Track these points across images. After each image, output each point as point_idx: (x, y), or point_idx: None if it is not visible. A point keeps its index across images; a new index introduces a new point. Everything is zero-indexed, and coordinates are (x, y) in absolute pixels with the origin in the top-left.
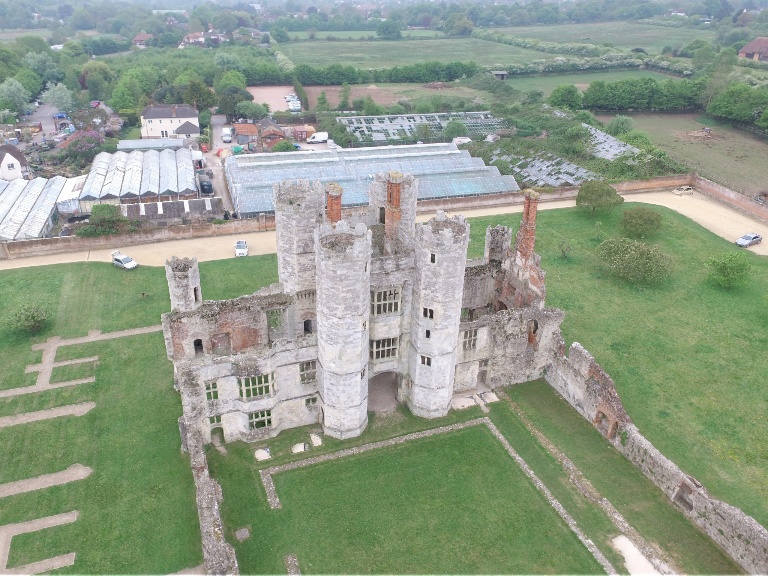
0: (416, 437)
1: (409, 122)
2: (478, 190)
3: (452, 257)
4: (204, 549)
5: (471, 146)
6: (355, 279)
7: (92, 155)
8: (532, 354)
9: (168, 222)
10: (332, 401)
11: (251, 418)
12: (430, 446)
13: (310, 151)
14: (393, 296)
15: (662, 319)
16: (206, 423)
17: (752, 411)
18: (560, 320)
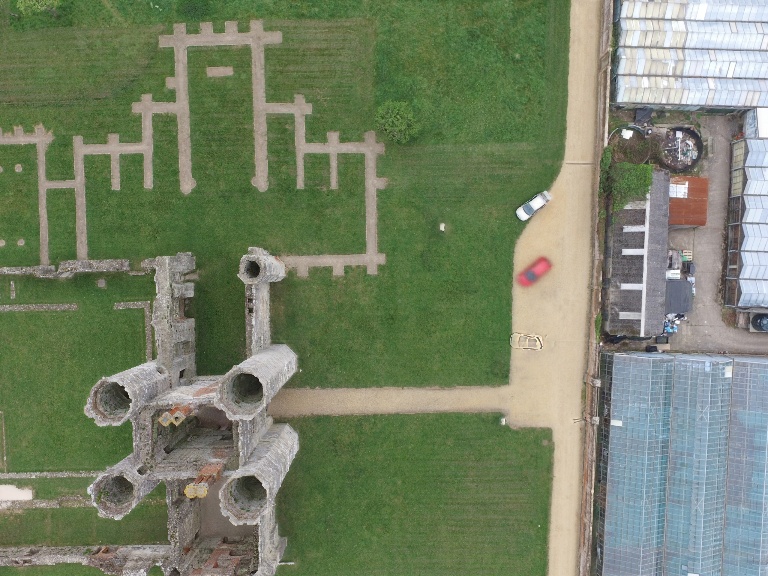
0: None
1: None
2: None
3: None
4: None
5: None
6: None
7: None
8: None
9: None
10: None
11: None
12: None
13: None
14: None
15: None
16: None
17: None
18: None
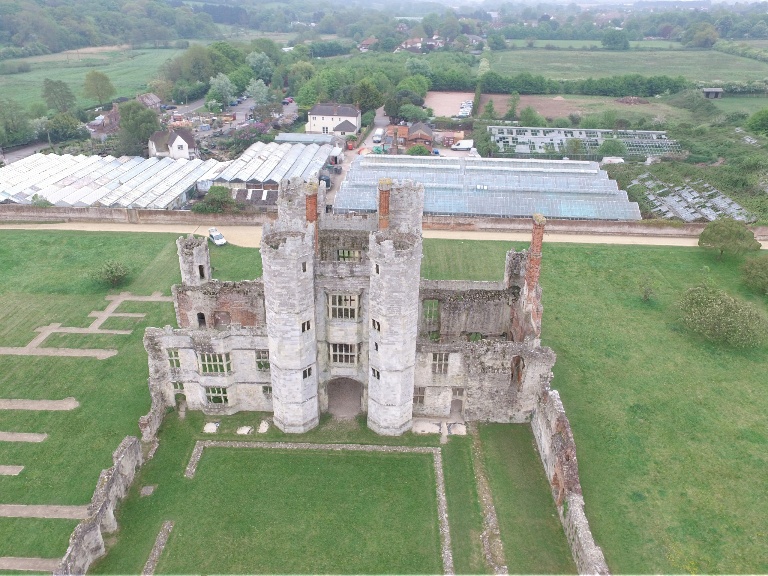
0: (355, 448)
1: (563, 136)
2: (589, 214)
3: (395, 271)
4: (95, 491)
5: (616, 167)
6: (289, 277)
7: (250, 144)
8: (515, 394)
9: (268, 208)
10: (277, 393)
11: (208, 392)
12: (362, 461)
13: (437, 157)
14: (349, 302)
15: (720, 391)
16: (170, 387)
17: (762, 524)
18: (549, 363)
